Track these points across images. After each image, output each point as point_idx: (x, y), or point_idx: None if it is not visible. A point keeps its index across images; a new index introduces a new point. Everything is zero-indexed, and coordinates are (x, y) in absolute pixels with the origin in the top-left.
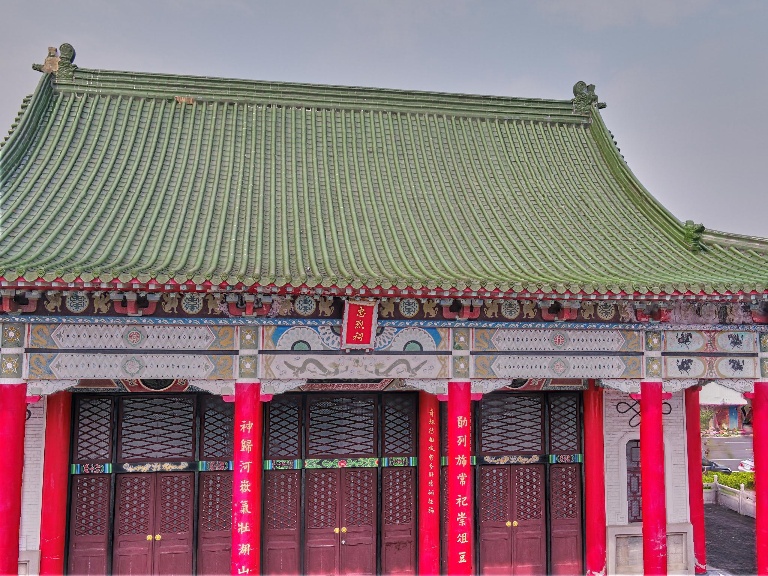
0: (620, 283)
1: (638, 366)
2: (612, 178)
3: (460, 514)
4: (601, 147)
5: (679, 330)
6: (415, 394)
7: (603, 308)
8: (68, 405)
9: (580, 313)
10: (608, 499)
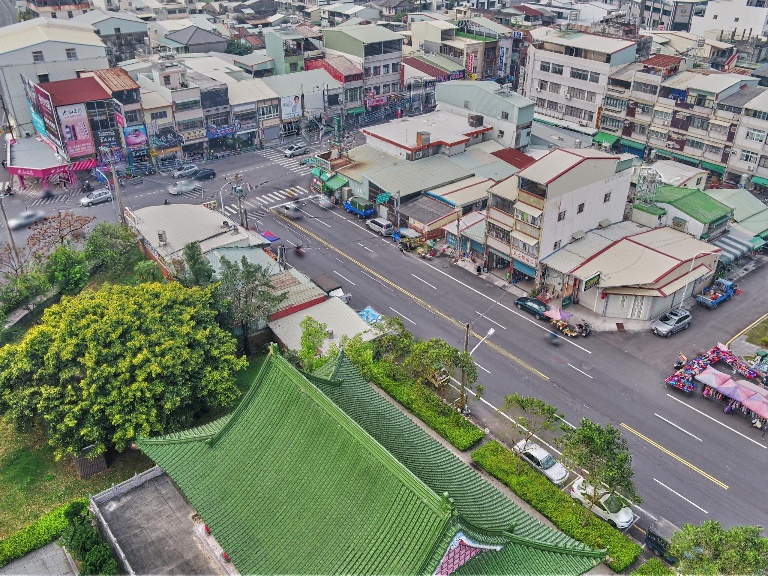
0: None
1: None
2: None
3: None
4: None
5: None
6: None
7: None
8: None
9: None
10: None
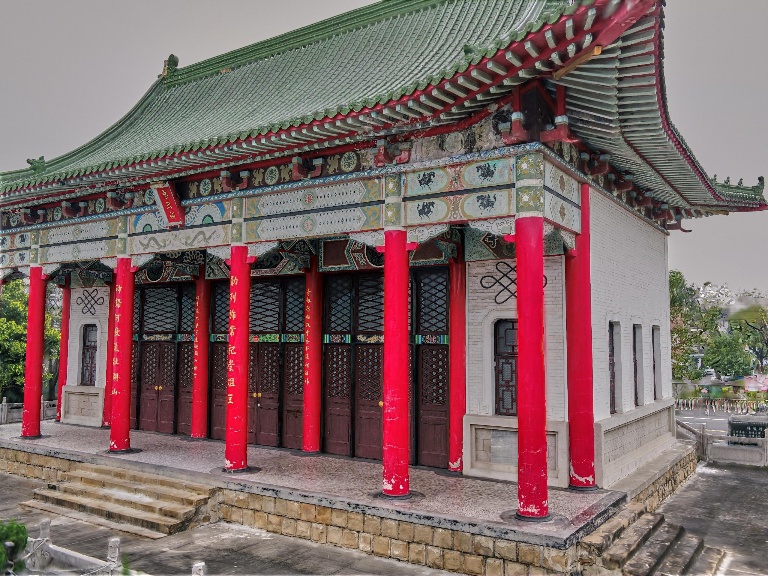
0: None
1: (378, 216)
2: None
3: (230, 361)
4: None
5: (420, 170)
6: None
7: (346, 160)
8: None
9: (326, 169)
10: (470, 385)
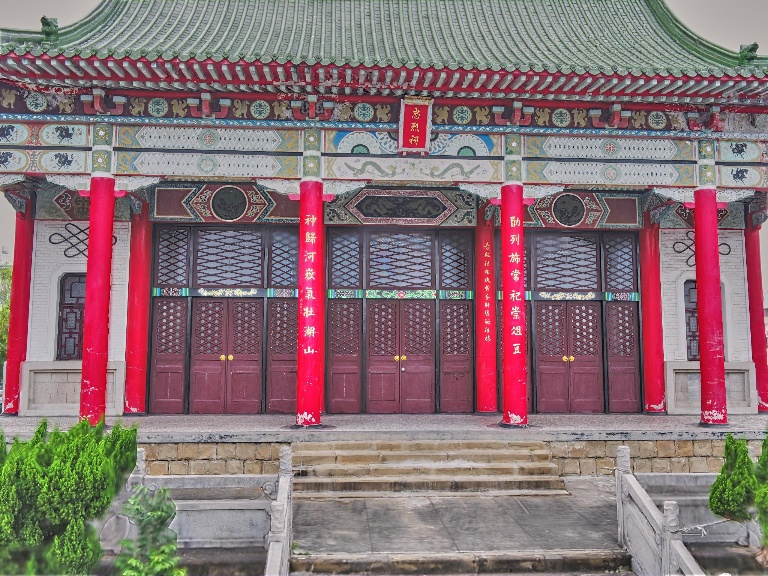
0: (668, 67)
1: (691, 174)
2: (666, 35)
3: (514, 308)
4: (655, 11)
5: (733, 140)
6: (471, 232)
7: (654, 118)
8: (149, 233)
9: (631, 122)
10: (666, 336)
